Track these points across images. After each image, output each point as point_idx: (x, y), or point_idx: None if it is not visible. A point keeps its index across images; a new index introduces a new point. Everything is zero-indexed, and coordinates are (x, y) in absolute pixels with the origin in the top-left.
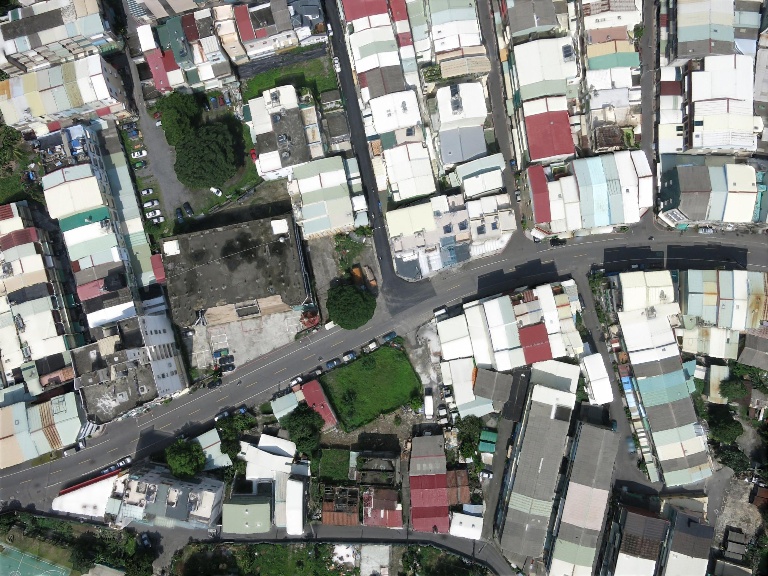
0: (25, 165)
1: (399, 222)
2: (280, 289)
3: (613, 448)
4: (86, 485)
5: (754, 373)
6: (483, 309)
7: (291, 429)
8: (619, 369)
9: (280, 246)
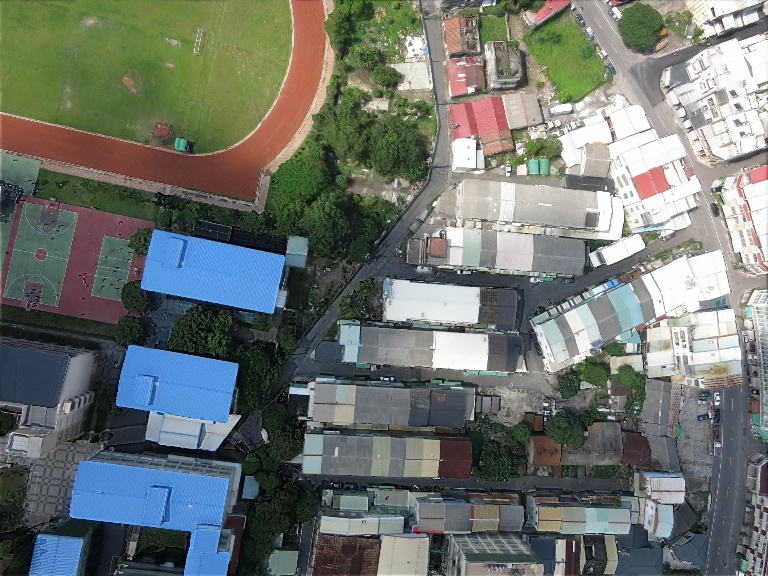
0: None
1: (731, 51)
2: None
3: (569, 269)
4: None
5: (640, 395)
6: (672, 134)
7: None
8: (622, 276)
9: None
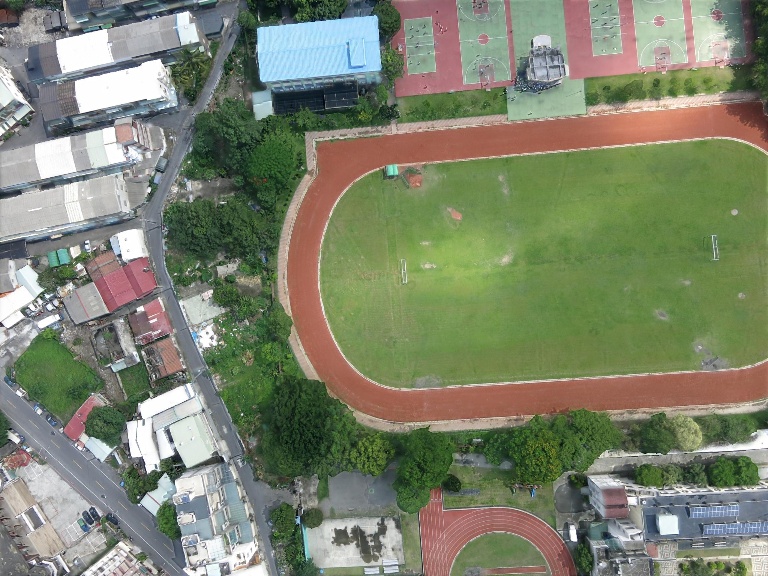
0: None
1: None
2: None
3: None
4: None
5: None
6: None
7: None
8: None
9: None
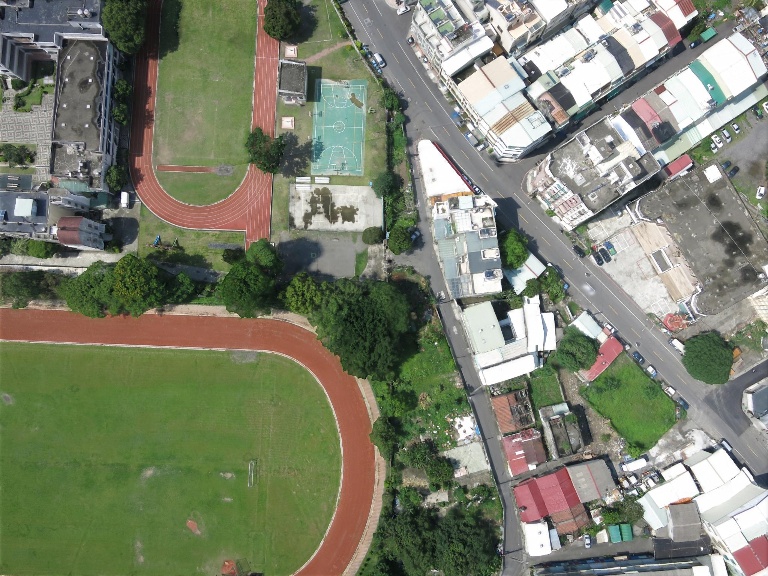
0: (718, 7)
1: None
2: (712, 289)
3: None
4: (451, 165)
5: None
6: None
7: (575, 341)
8: None
9: (752, 275)
